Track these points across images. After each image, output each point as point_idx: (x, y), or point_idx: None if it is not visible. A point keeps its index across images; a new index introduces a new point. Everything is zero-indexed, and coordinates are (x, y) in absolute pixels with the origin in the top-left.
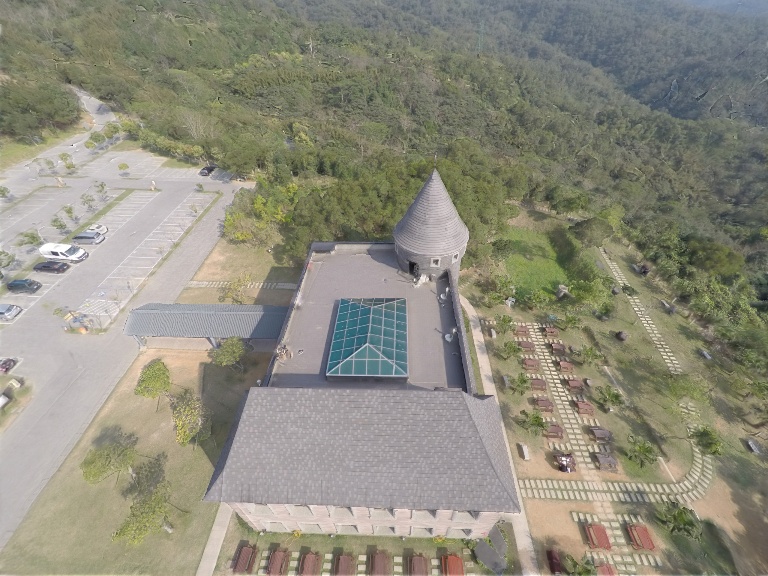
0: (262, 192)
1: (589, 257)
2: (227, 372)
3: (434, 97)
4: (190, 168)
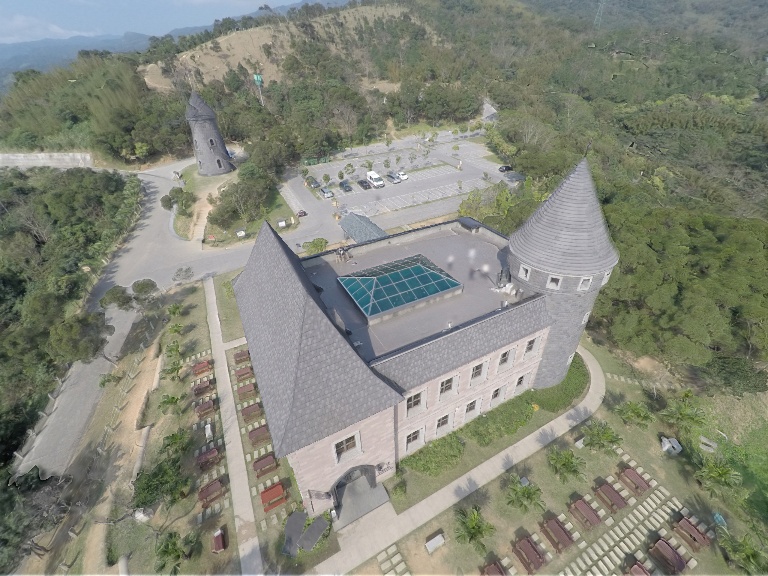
0: (519, 192)
1: None
2: None
3: None
4: (499, 164)
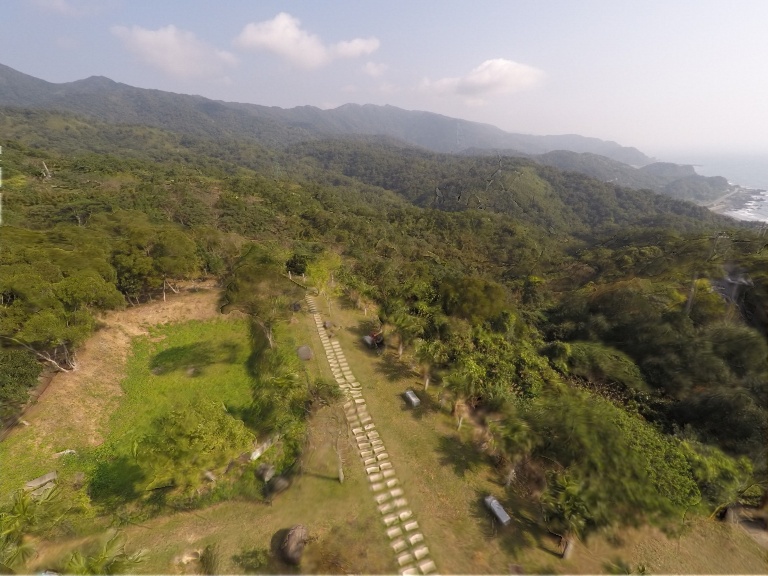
0: None
1: (289, 343)
2: None
3: (212, 210)
4: None
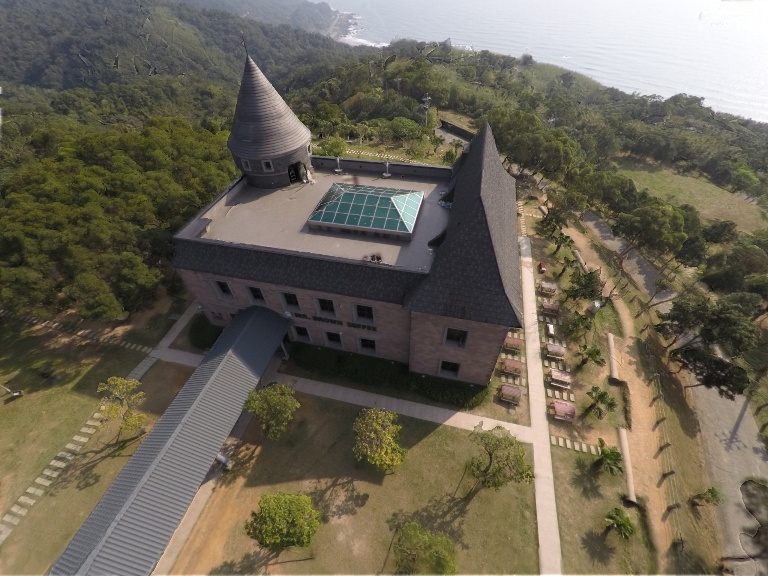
0: None
1: None
2: (279, 445)
3: None
4: None
